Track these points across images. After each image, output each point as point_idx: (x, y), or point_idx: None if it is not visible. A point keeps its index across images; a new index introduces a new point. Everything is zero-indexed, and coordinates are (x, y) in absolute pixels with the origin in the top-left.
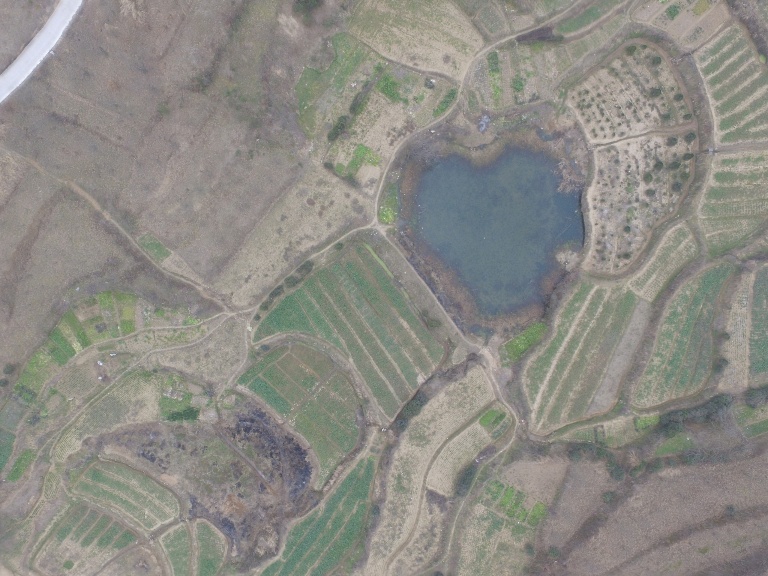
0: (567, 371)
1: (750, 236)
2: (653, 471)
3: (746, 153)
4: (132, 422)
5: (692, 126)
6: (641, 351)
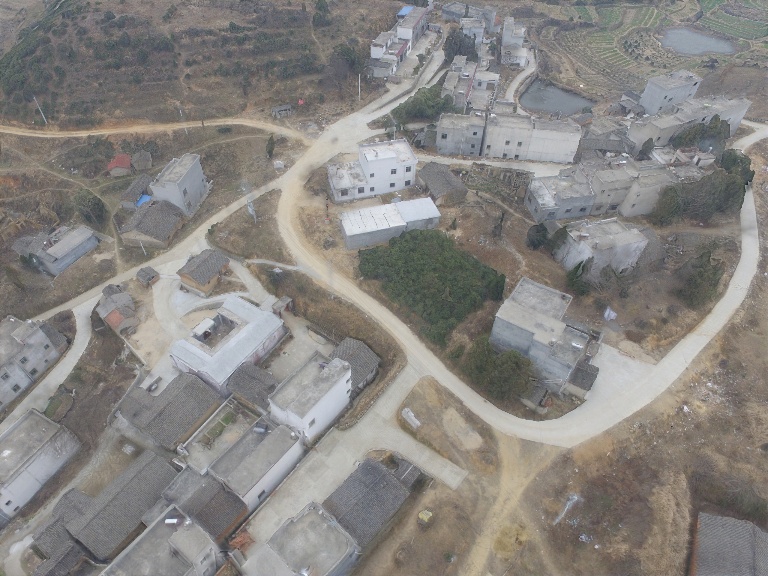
0: None
1: None
2: None
3: (603, 46)
4: None
5: None
6: None
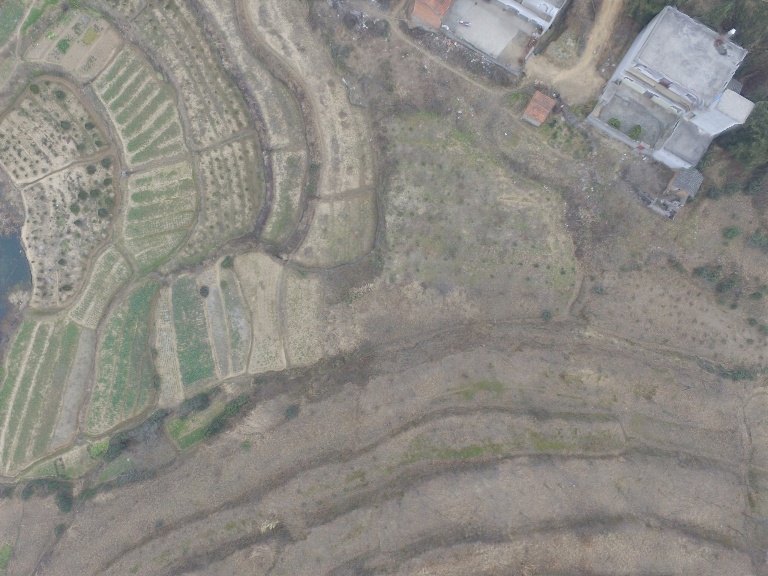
0: (25, 410)
1: (178, 249)
2: (85, 499)
3: (159, 170)
4: None
5: (111, 151)
6: None
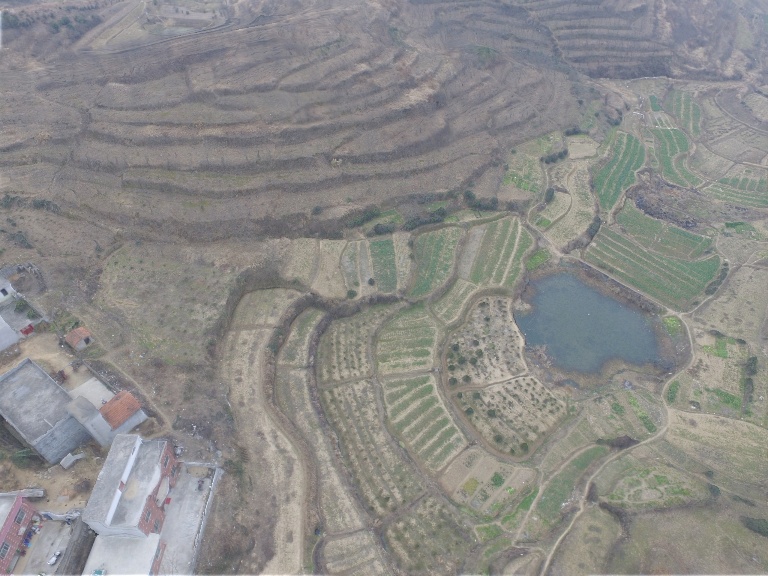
0: (506, 243)
1: (394, 318)
2: None
3: (406, 370)
4: (765, 220)
5: (450, 393)
6: (461, 252)
